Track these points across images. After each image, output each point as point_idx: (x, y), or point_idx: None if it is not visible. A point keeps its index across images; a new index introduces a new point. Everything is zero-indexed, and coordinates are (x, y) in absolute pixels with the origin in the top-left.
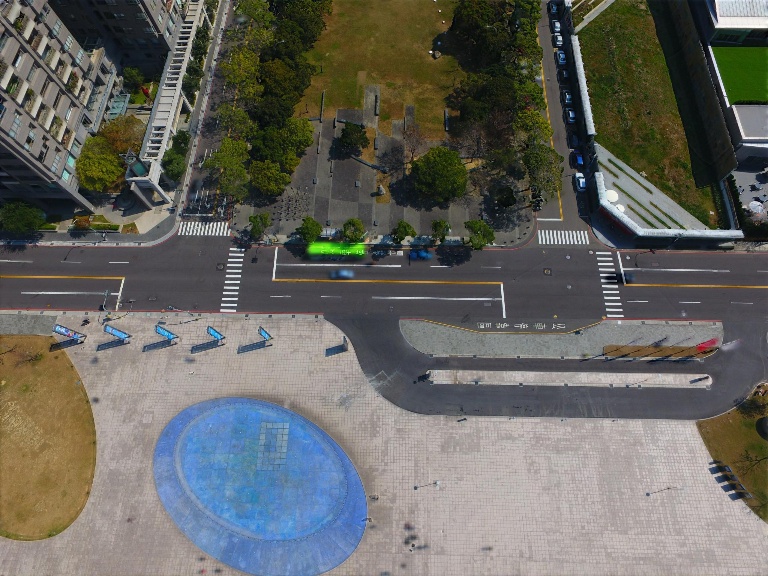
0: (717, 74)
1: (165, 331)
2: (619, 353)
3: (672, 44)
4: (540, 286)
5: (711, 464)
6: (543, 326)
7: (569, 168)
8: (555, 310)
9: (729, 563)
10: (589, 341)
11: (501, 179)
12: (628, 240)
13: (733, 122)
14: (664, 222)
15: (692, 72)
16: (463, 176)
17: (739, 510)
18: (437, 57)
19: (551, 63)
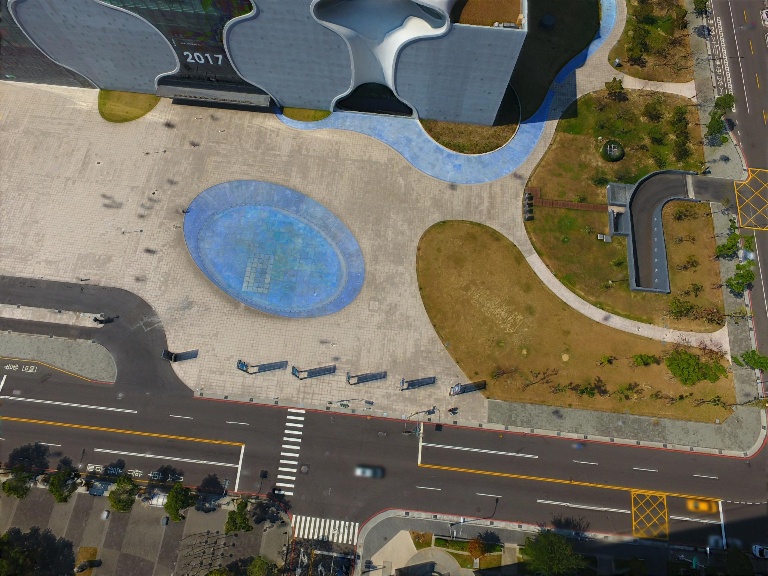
0: None
1: (365, 393)
2: None
3: None
4: None
5: None
6: None
7: None
8: None
9: None
10: None
11: None
12: None
13: None
14: None
15: None
16: None
17: None
18: None
19: None
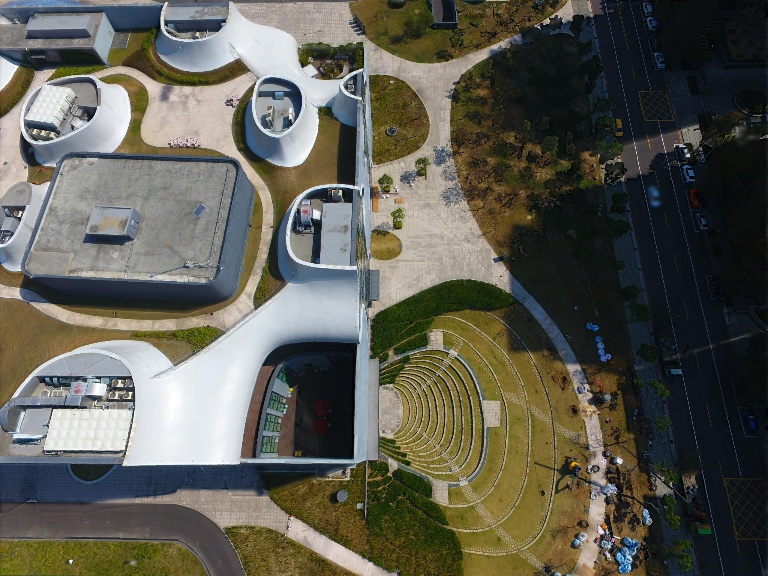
0: None
1: None
2: None
3: None
4: None
5: (351, 20)
6: None
7: None
8: None
9: None
10: None
11: None
12: None
13: None
14: None
15: None
16: None
17: (360, 39)
18: None
19: None
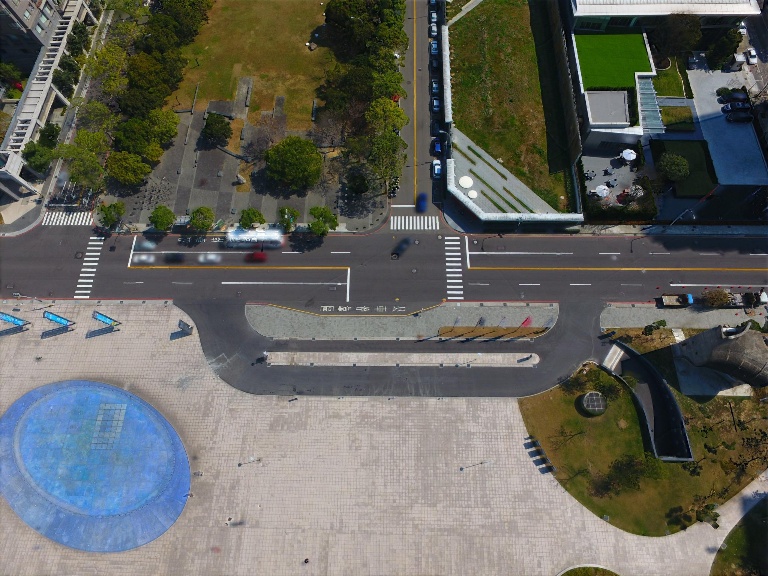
0: (576, 61)
1: (18, 317)
2: (453, 334)
3: (544, 33)
4: (386, 270)
5: (526, 439)
6: (384, 309)
7: (429, 156)
8: (397, 293)
9: (530, 533)
10: (426, 323)
11: (361, 167)
12: (477, 225)
13: (584, 108)
14: (515, 207)
15: (557, 60)
16: (316, 164)
17: (547, 483)
18: (313, 49)
19: (424, 53)
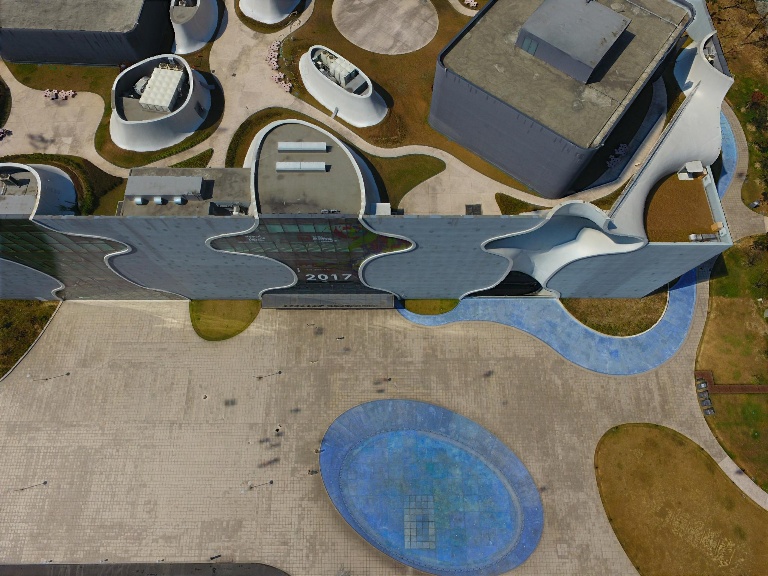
0: None
1: None
2: None
3: None
4: None
5: None
6: None
7: None
8: None
9: None
10: None
11: None
12: None
13: None
14: None
15: None
16: None
17: None
18: None
19: None
